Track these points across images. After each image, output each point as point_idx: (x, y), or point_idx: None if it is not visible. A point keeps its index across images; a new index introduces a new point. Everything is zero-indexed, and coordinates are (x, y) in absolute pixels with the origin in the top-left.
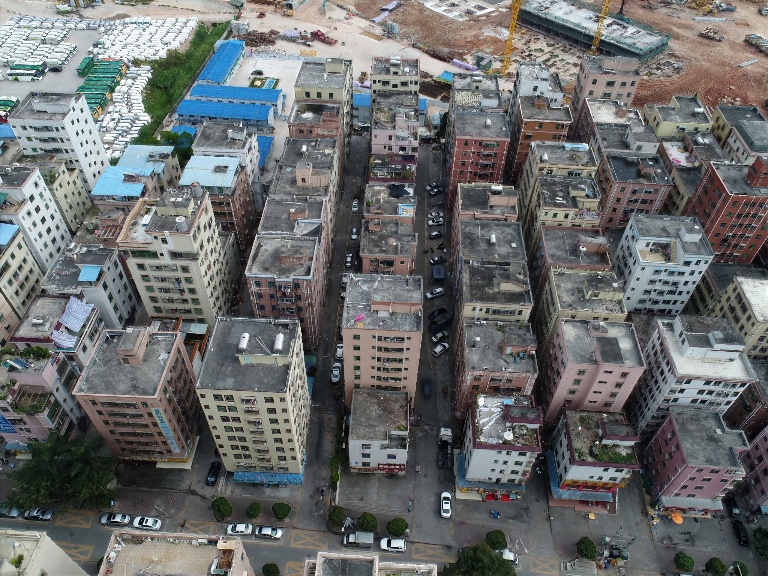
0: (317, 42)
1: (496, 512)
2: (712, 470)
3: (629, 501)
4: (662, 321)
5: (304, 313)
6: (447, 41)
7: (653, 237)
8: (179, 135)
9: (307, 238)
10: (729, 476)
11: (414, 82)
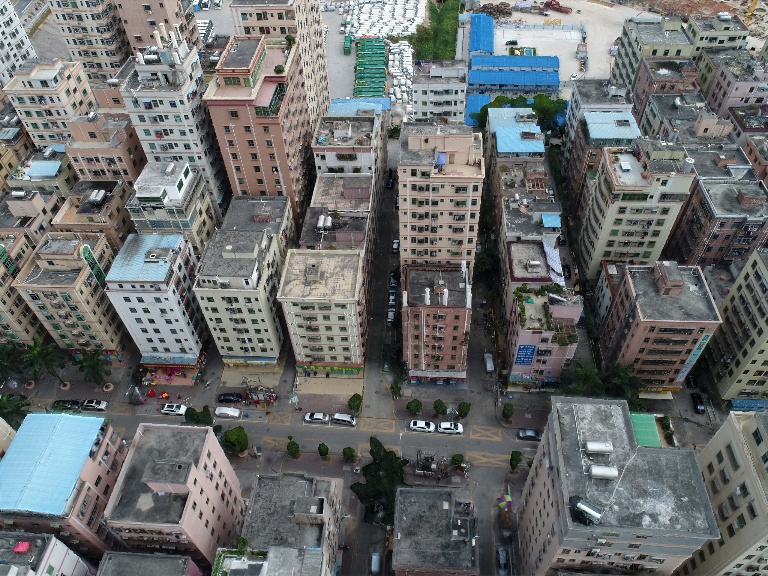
0: (551, 11)
1: None
2: None
3: None
4: None
5: (748, 254)
6: (662, 6)
7: None
8: (517, 99)
9: (750, 182)
10: None
11: (742, 37)
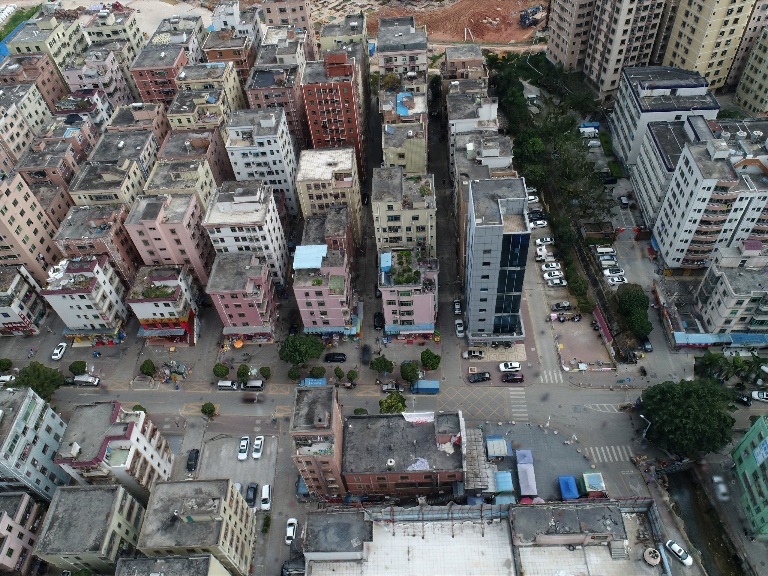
0: None
1: (97, 352)
2: (231, 295)
3: (210, 337)
4: (217, 189)
5: None
6: None
7: (237, 126)
8: None
9: None
10: (249, 300)
11: (123, 30)
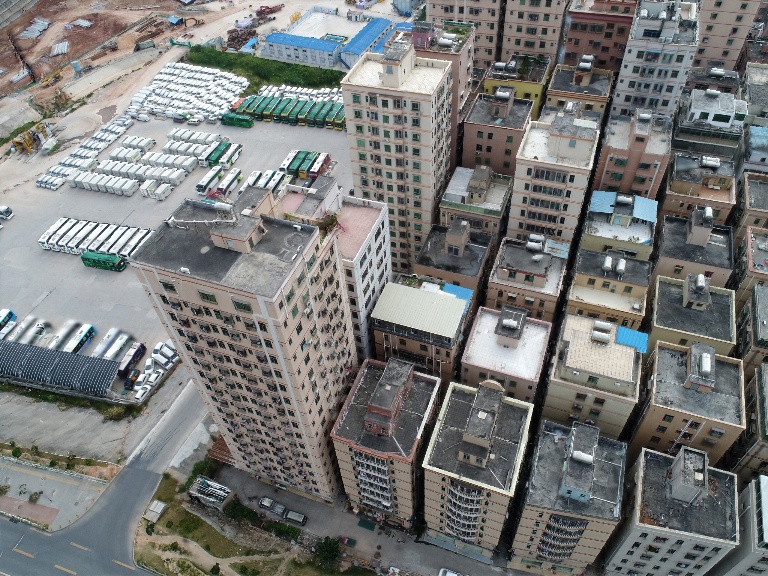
0: (269, 16)
1: None
2: None
3: None
4: None
5: None
6: None
7: None
8: None
9: None
10: None
11: None
